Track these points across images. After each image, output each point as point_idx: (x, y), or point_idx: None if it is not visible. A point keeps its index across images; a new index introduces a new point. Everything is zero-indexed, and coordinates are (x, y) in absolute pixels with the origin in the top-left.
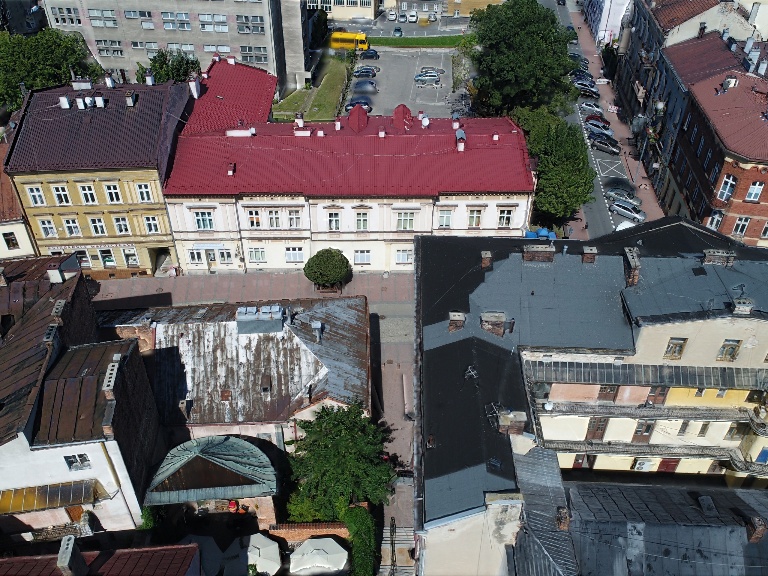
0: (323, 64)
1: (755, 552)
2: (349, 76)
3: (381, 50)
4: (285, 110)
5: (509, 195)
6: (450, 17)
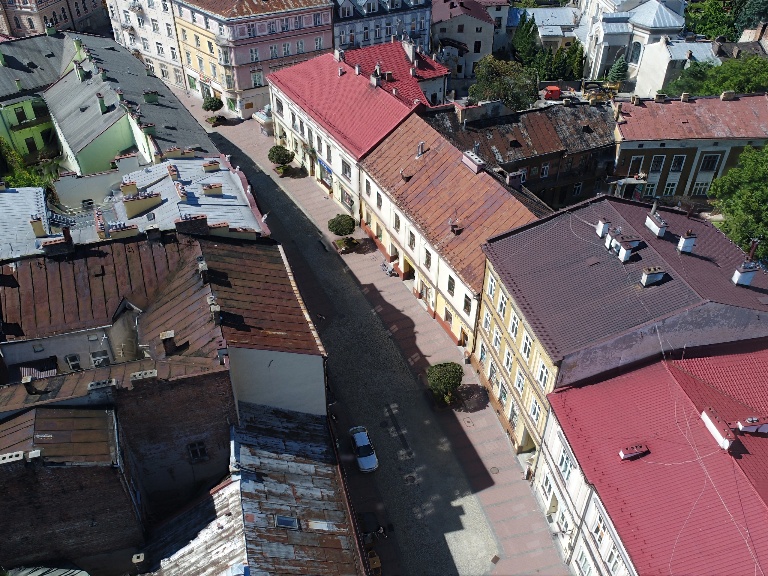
0: None
1: None
2: None
3: None
4: None
5: None
6: None
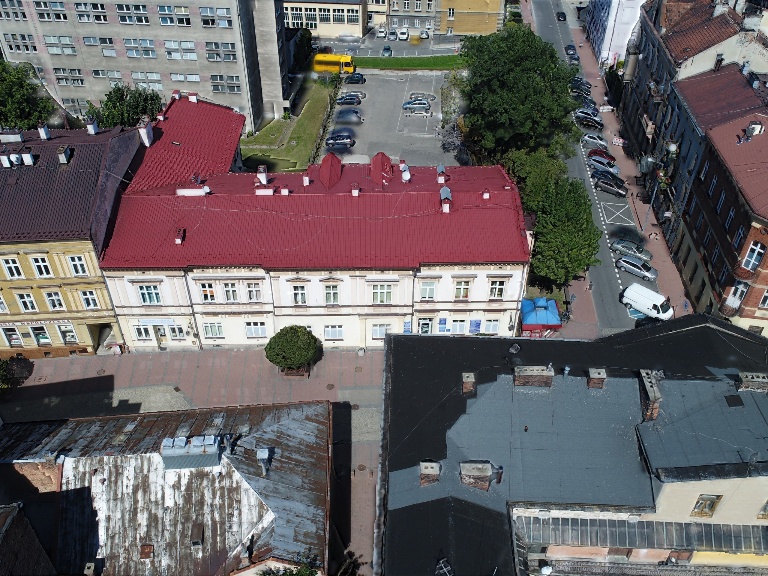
0: (305, 89)
1: None
2: (332, 104)
3: (368, 73)
4: (260, 143)
5: (501, 265)
6: (443, 35)
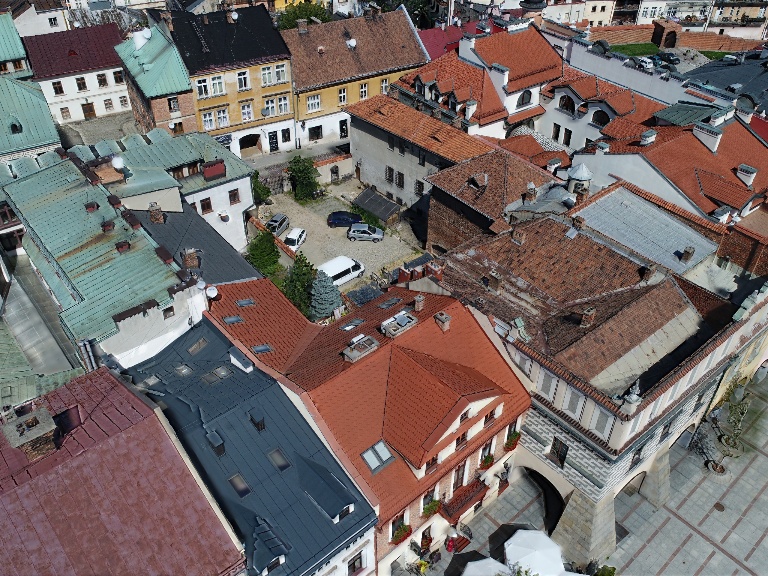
0: None
1: None
2: None
3: None
4: None
5: None
6: None
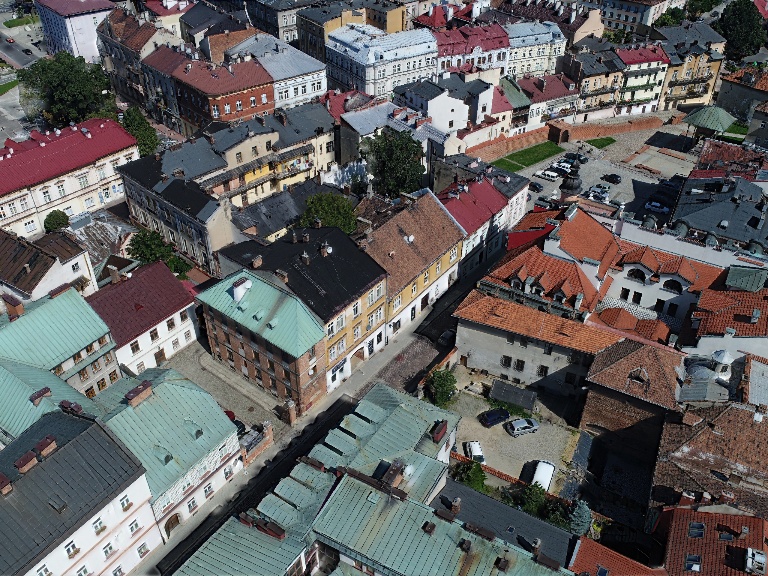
0: None
1: (294, 196)
2: None
3: None
4: None
5: (128, 149)
6: None
